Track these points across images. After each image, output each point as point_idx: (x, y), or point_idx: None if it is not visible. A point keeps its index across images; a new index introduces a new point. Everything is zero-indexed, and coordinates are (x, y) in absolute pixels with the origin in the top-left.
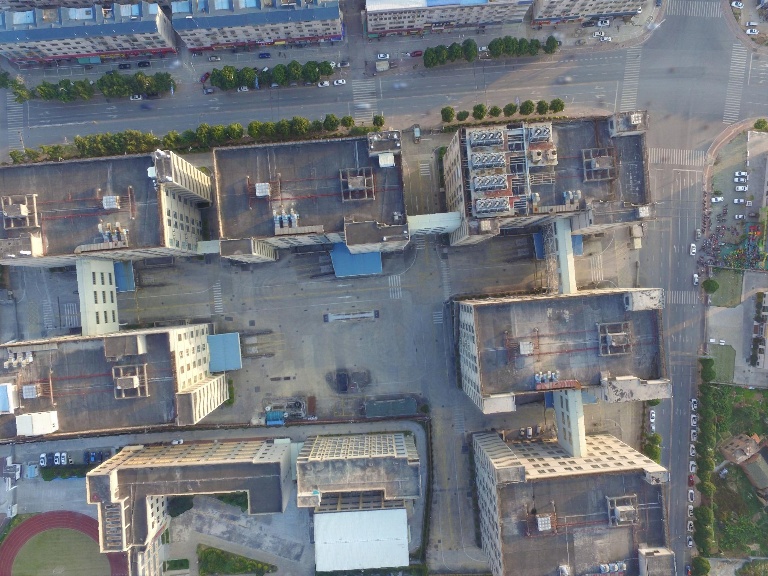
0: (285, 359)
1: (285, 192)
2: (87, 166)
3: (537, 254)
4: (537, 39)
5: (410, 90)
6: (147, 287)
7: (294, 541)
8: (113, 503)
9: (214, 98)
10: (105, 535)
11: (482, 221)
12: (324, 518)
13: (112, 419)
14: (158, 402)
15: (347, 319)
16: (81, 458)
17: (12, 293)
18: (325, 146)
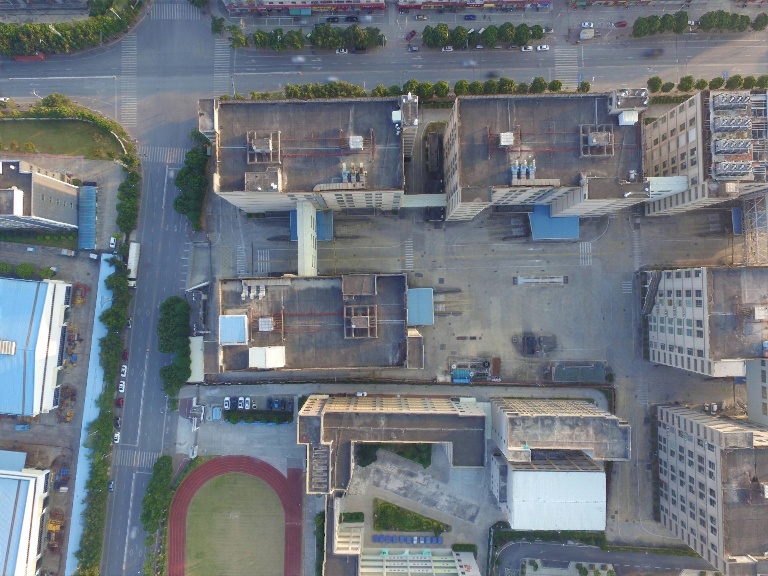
0: (472, 319)
1: (524, 144)
2: (330, 107)
3: (734, 229)
4: (747, 15)
5: (612, 60)
6: (341, 238)
7: (470, 502)
8: (321, 445)
9: (417, 56)
10: (311, 476)
11: (727, 183)
12: (523, 476)
13: (338, 358)
14: (384, 344)
15: (536, 283)
16: (264, 404)
17: (208, 236)
18: (565, 101)
